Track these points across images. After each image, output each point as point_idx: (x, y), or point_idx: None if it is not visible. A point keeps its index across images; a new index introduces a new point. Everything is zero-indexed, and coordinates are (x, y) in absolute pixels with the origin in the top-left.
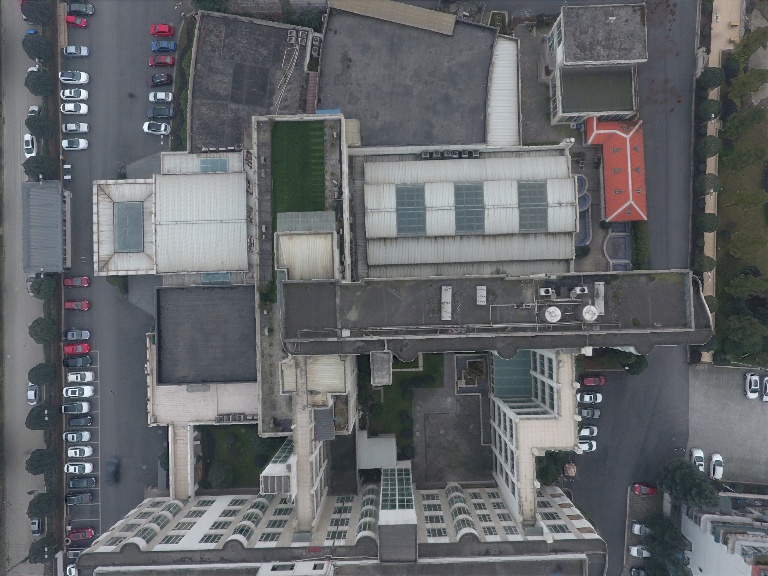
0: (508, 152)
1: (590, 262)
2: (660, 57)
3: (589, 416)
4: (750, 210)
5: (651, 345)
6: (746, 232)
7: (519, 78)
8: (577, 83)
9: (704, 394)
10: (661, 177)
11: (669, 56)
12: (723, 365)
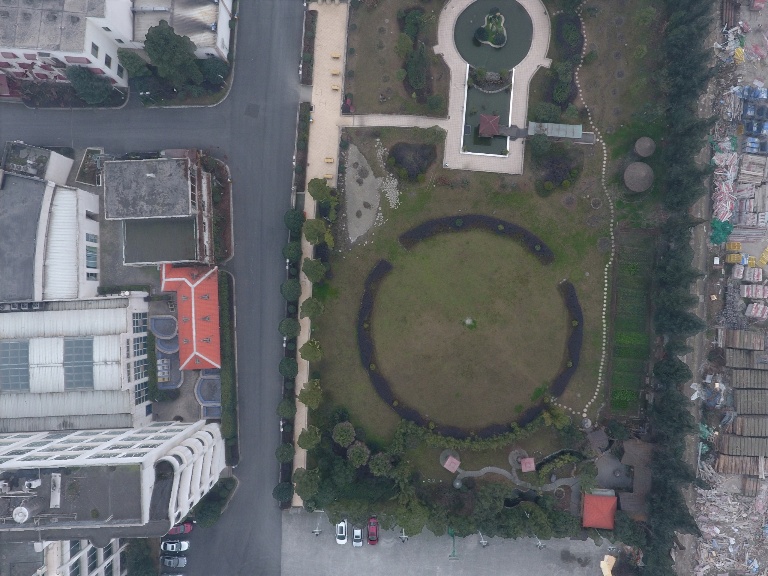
0: (77, 301)
1: (182, 405)
2: (257, 194)
3: (171, 566)
4: (345, 350)
5: (108, 538)
6: (341, 372)
7: (77, 229)
8: (141, 232)
9: (297, 539)
10: (255, 317)
11: (266, 193)
12: (314, 510)
